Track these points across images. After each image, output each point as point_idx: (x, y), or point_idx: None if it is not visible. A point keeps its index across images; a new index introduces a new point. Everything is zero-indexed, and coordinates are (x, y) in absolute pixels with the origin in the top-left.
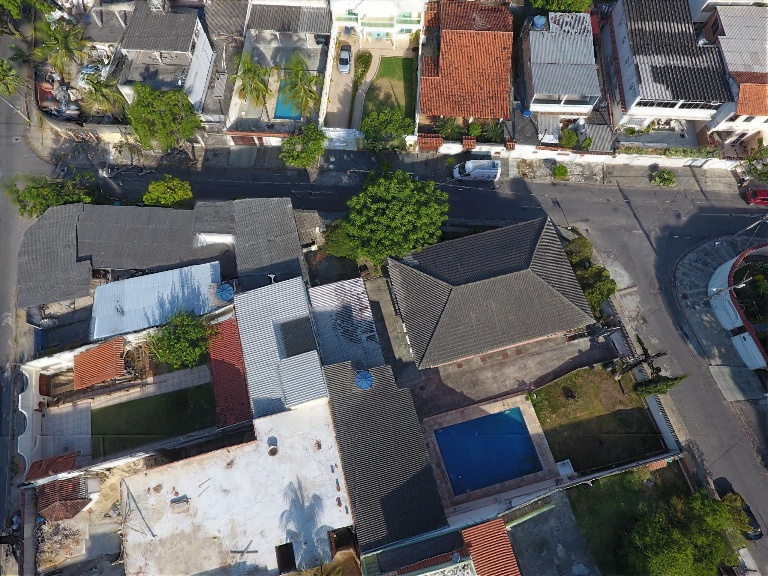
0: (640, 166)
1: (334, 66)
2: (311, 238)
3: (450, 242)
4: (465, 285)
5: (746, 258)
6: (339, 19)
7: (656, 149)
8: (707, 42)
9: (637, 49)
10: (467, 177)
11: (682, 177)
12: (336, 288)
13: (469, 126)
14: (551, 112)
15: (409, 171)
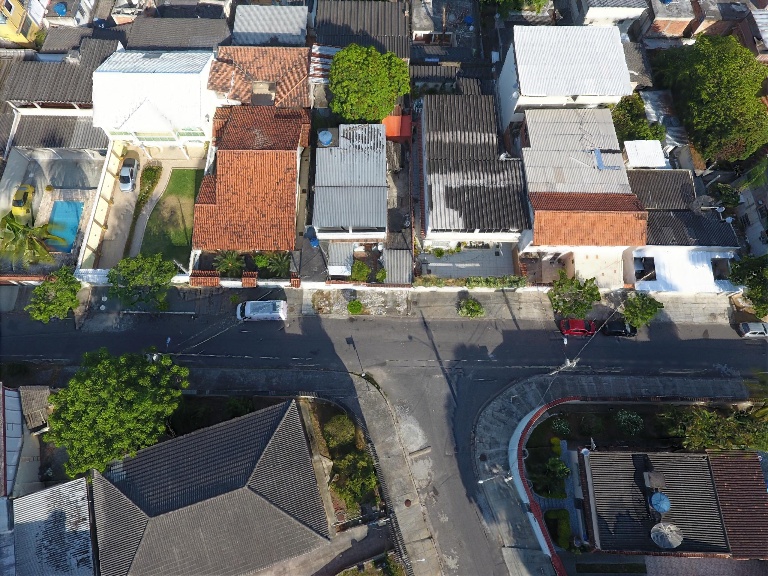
0: (448, 293)
1: (118, 182)
2: (41, 420)
3: (172, 441)
4: (165, 514)
5: (550, 408)
6: (114, 133)
7: (457, 279)
8: (509, 156)
9: (433, 166)
10: (249, 319)
11: (493, 304)
12: (50, 495)
13: (254, 257)
14: (343, 239)
15: (190, 310)
